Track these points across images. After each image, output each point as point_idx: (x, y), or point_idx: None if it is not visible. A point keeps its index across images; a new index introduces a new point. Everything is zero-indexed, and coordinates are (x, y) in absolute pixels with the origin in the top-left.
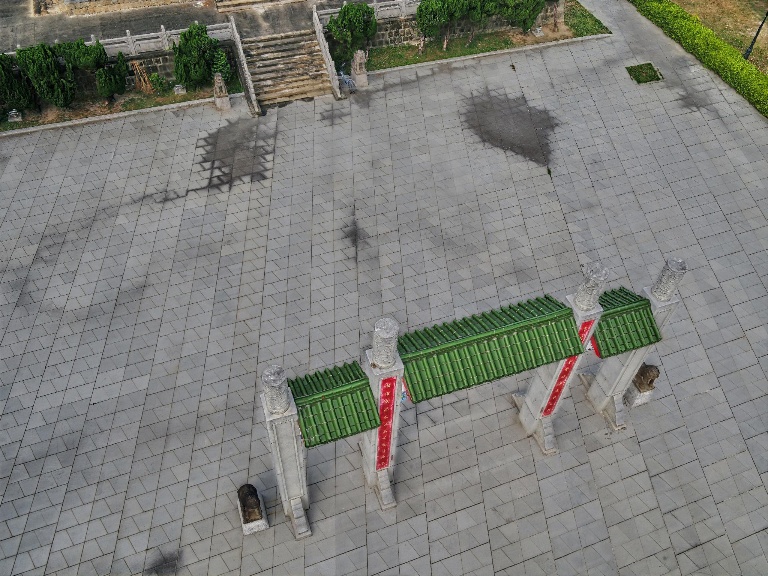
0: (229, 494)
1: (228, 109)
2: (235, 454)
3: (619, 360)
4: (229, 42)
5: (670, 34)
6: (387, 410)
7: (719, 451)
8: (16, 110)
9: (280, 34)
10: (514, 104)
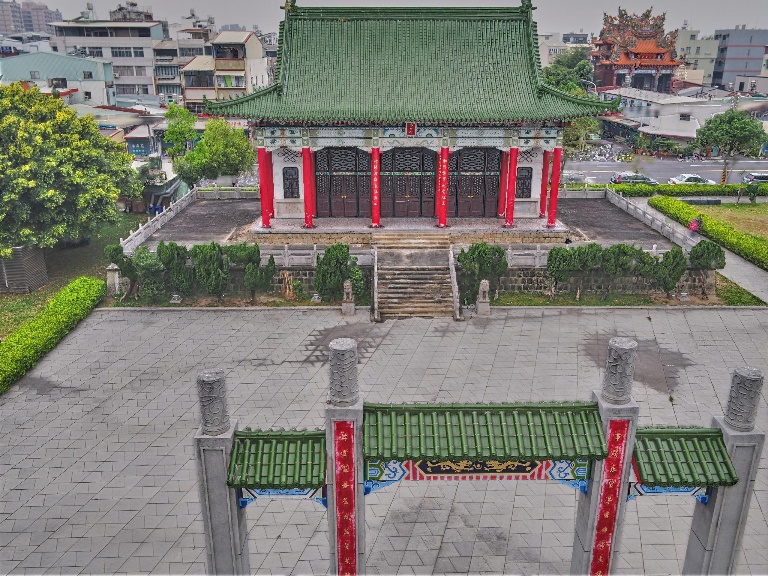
0: None
1: (351, 315)
2: None
3: (700, 542)
4: (369, 267)
5: None
6: (347, 488)
7: None
8: (180, 297)
9: (417, 266)
10: (643, 344)
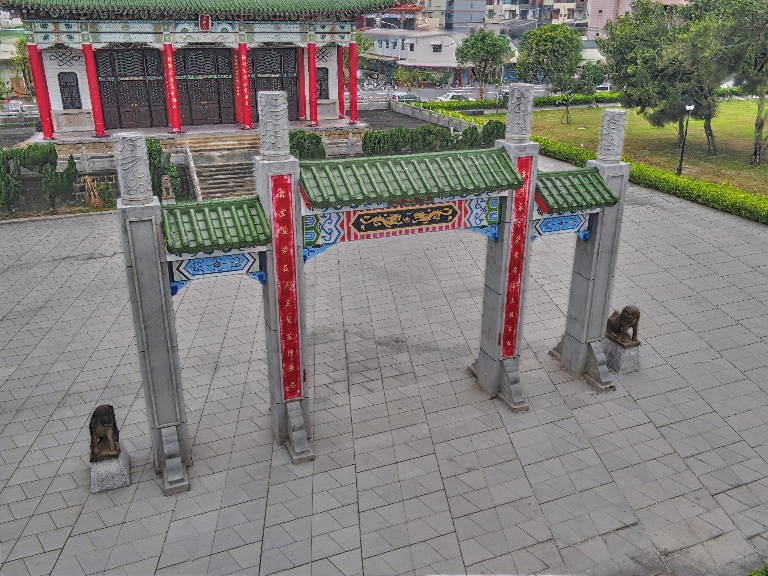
0: (83, 456)
1: None
2: None
3: (584, 277)
4: (183, 166)
5: None
6: (286, 253)
7: (740, 404)
8: None
9: (233, 162)
10: None
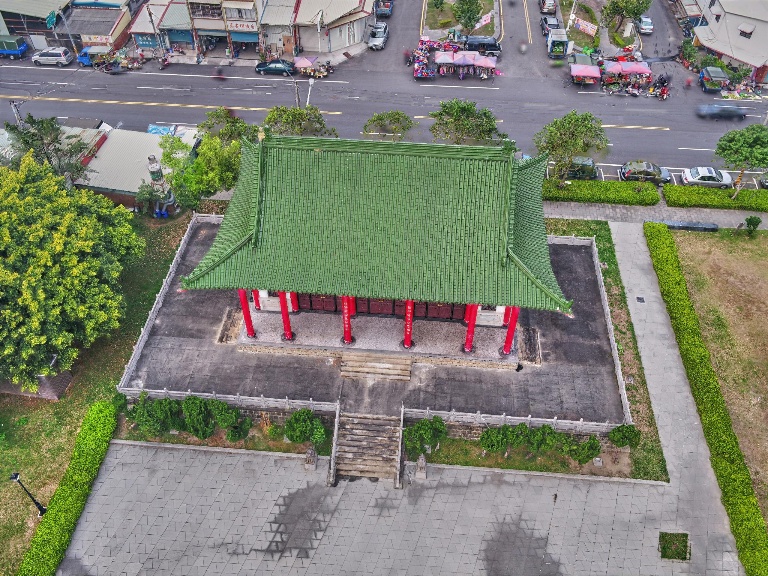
0: None
1: (313, 470)
2: None
3: None
4: (333, 413)
5: (725, 504)
6: None
7: None
8: None
9: (373, 415)
10: (534, 544)
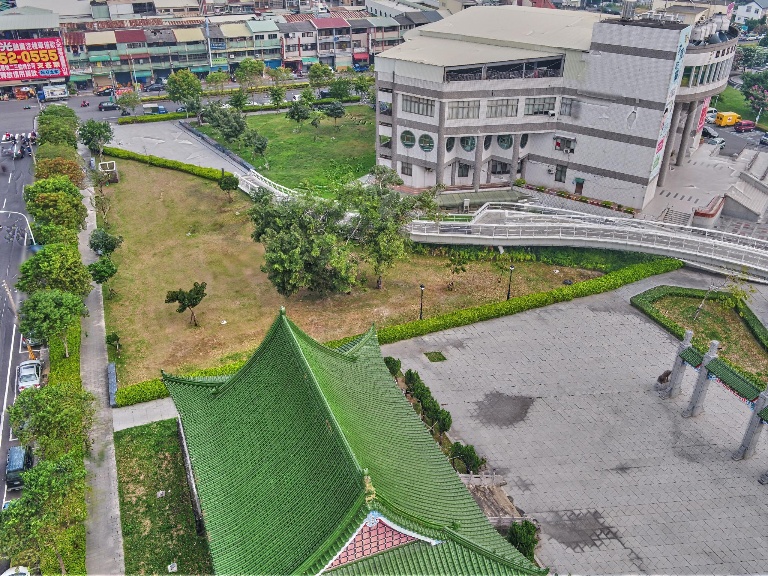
0: None
1: None
2: (767, 499)
3: None
4: None
5: (394, 341)
6: None
7: None
8: None
9: None
10: (483, 406)
